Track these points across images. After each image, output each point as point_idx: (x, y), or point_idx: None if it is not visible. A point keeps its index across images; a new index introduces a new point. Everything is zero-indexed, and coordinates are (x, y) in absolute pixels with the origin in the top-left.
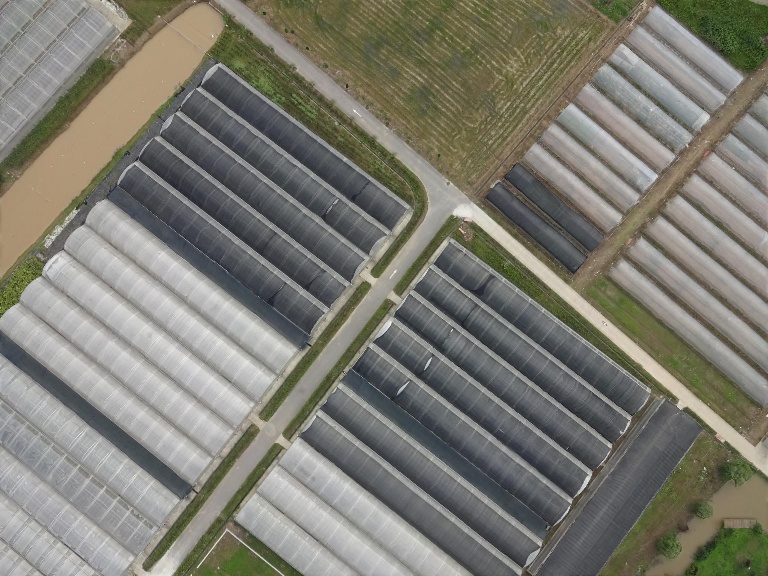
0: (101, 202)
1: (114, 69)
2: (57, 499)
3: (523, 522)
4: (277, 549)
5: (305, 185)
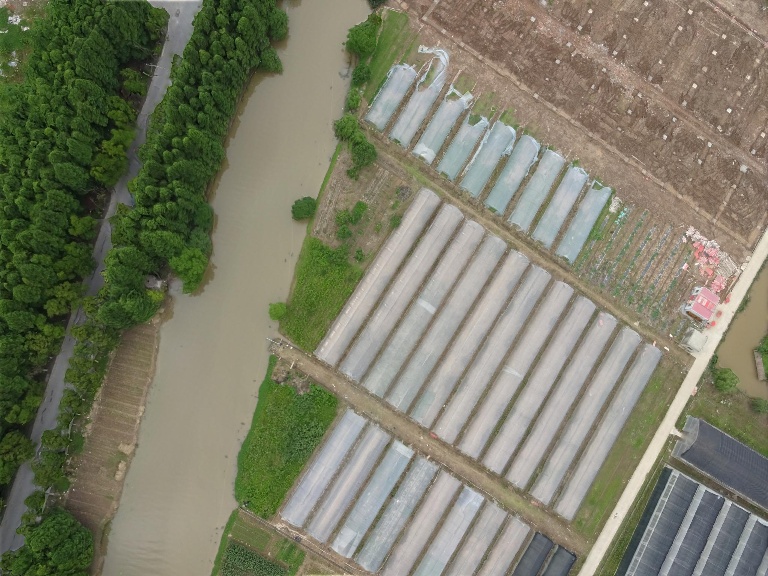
0: None
1: None
2: None
3: None
4: None
5: None
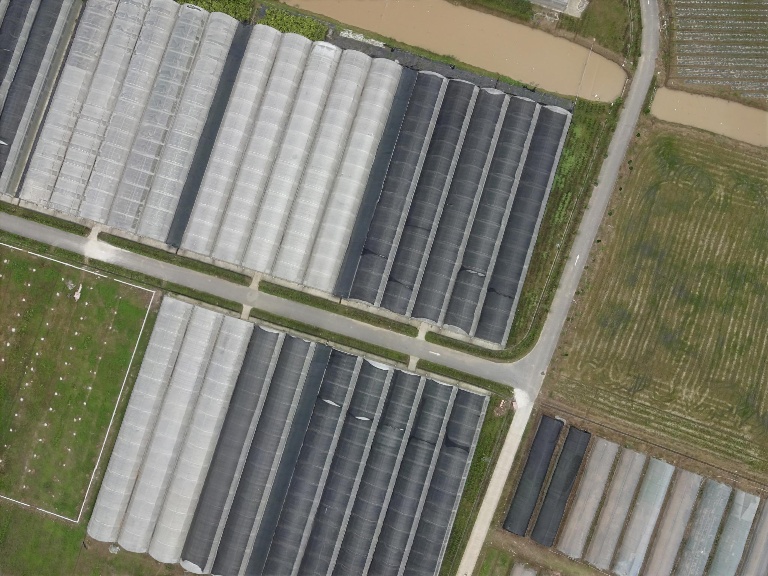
0: (398, 64)
1: (527, 21)
2: (130, 138)
3: (252, 559)
4: (152, 343)
5: (486, 239)
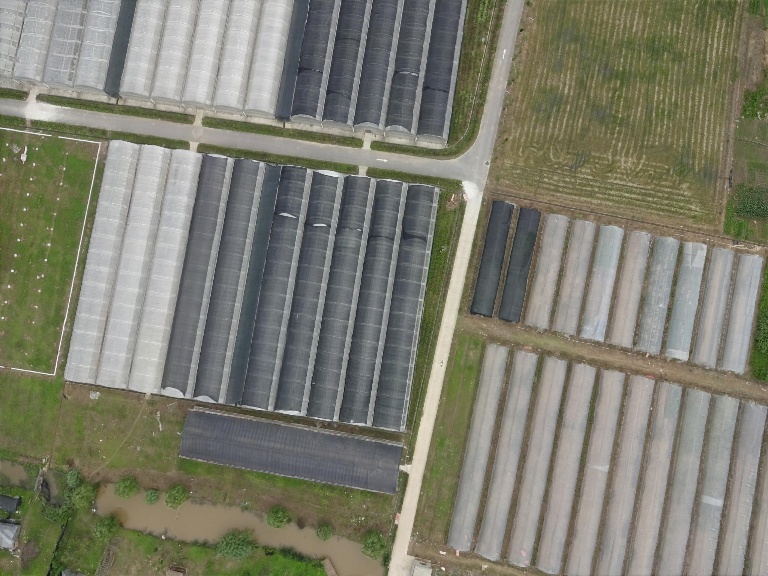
0: None
1: None
2: None
3: (231, 378)
4: (104, 187)
5: (415, 43)
